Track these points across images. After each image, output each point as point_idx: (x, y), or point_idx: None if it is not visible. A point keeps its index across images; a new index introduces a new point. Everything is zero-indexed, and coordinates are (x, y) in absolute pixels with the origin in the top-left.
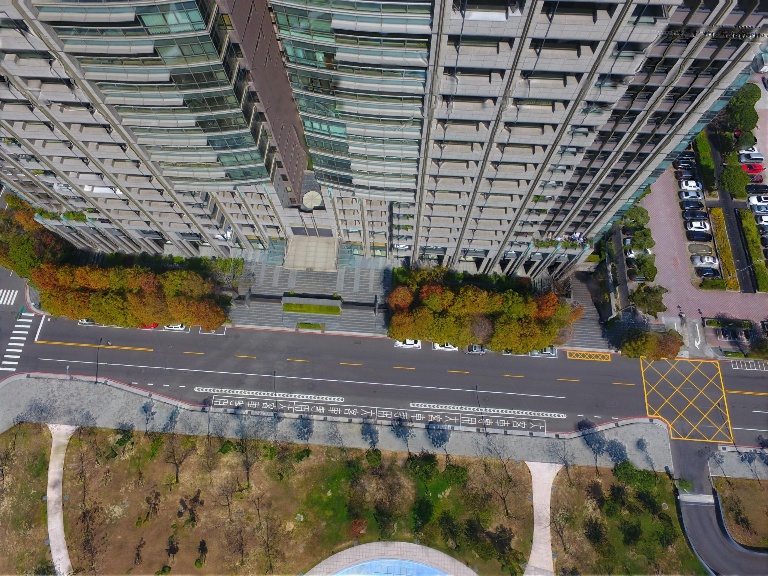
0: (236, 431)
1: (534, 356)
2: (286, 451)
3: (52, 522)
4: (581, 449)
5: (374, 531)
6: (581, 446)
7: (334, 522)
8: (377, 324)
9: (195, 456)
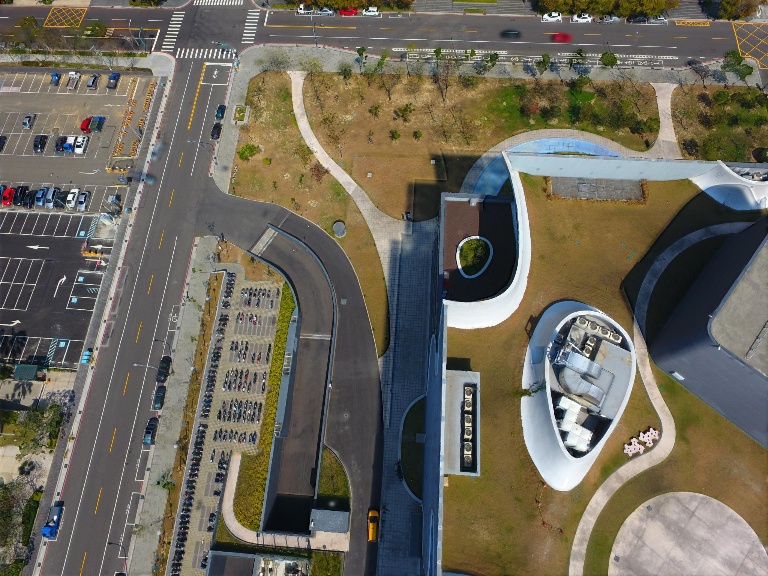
0: (429, 71)
1: (650, 24)
2: (468, 81)
3: (301, 125)
4: (691, 75)
5: (541, 123)
6: (691, 73)
7: (511, 119)
8: (526, 8)
9: (401, 85)
